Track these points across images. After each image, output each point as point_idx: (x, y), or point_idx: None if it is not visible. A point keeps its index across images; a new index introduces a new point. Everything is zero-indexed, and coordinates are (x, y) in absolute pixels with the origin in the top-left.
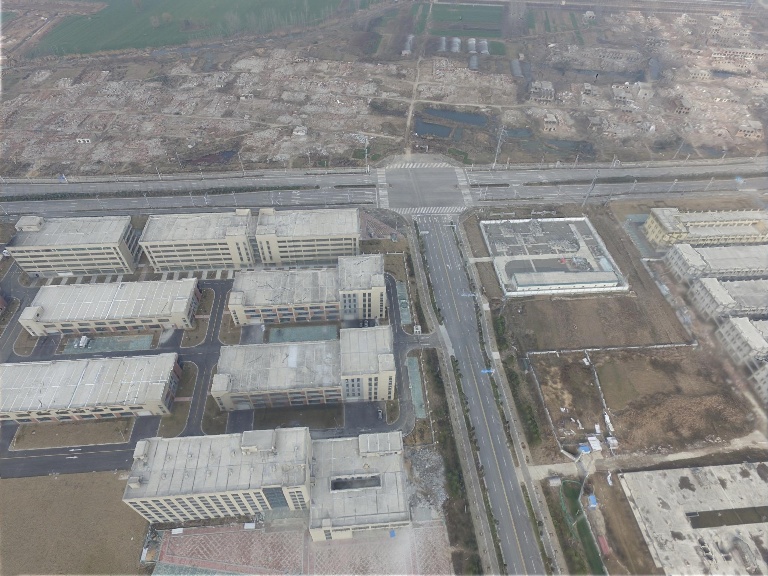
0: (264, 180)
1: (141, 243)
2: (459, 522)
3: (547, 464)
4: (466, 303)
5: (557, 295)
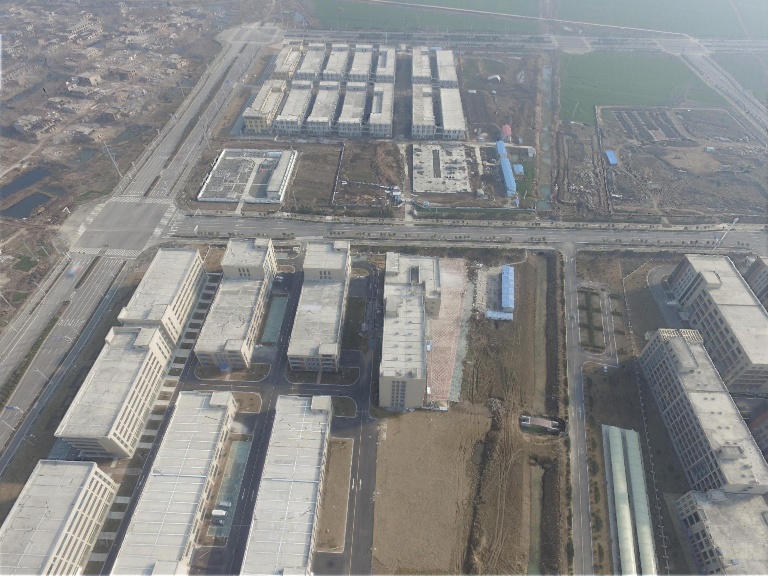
0: (11, 354)
1: (109, 435)
2: (433, 251)
3: (405, 214)
4: (279, 223)
5: (289, 181)
